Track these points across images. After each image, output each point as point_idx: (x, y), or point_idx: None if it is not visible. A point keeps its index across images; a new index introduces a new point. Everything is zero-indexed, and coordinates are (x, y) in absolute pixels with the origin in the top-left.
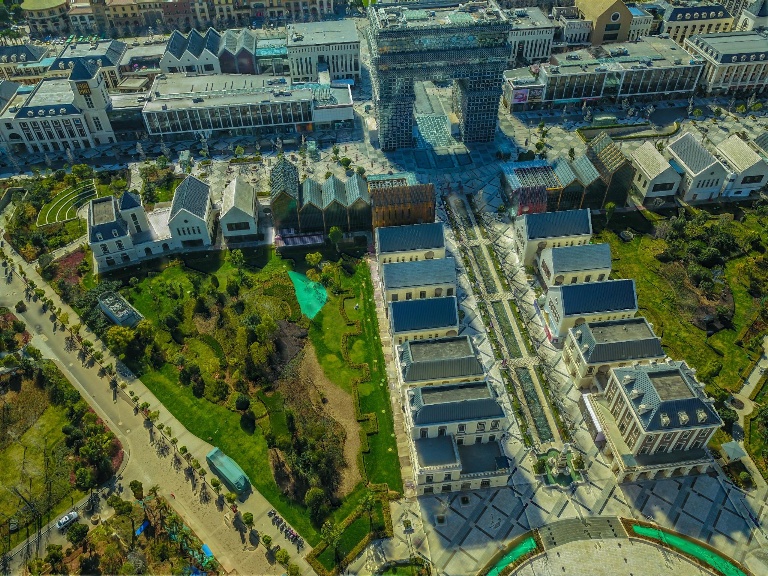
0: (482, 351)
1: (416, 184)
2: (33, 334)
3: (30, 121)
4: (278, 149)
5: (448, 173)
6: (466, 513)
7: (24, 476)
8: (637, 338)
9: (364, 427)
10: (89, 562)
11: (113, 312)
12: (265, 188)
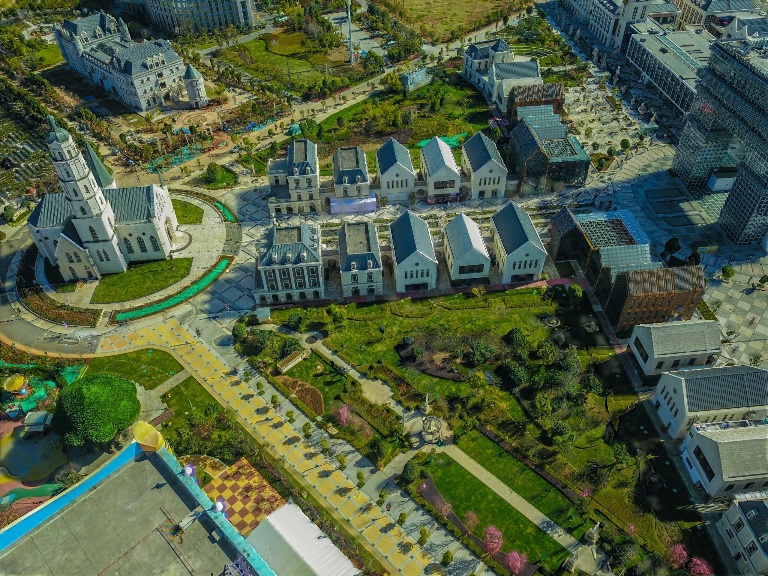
0: (383, 213)
1: (568, 160)
2: (404, 65)
3: (598, 5)
4: (644, 116)
5: (642, 208)
6: (257, 200)
7: (312, 81)
8: (351, 247)
9: (323, 166)
10: (264, 102)
11: (408, 72)
12: (576, 116)
